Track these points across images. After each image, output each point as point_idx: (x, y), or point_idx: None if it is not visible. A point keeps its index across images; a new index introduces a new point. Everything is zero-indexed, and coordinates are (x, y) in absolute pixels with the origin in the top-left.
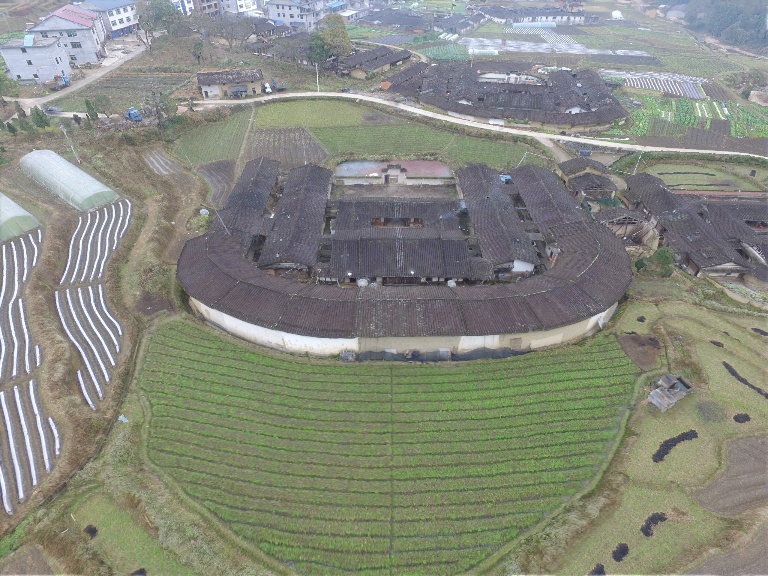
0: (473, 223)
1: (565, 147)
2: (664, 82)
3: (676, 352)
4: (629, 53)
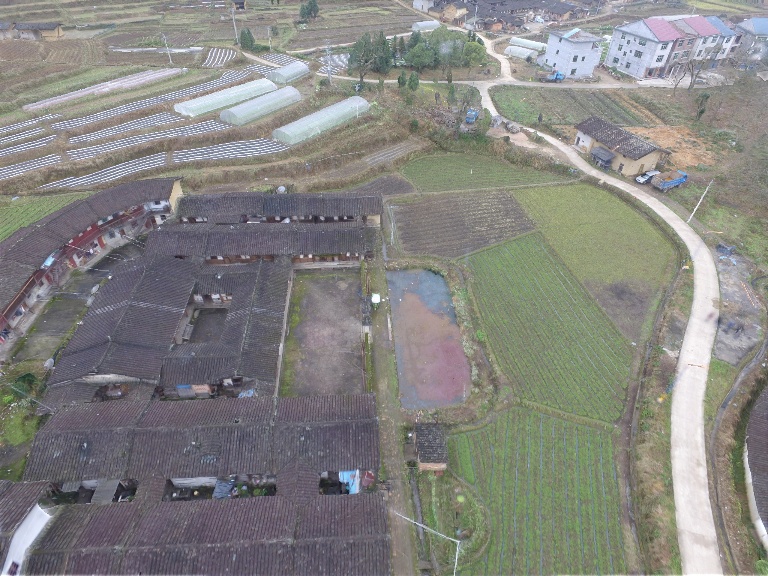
0: None
1: None
2: None
3: None
4: None
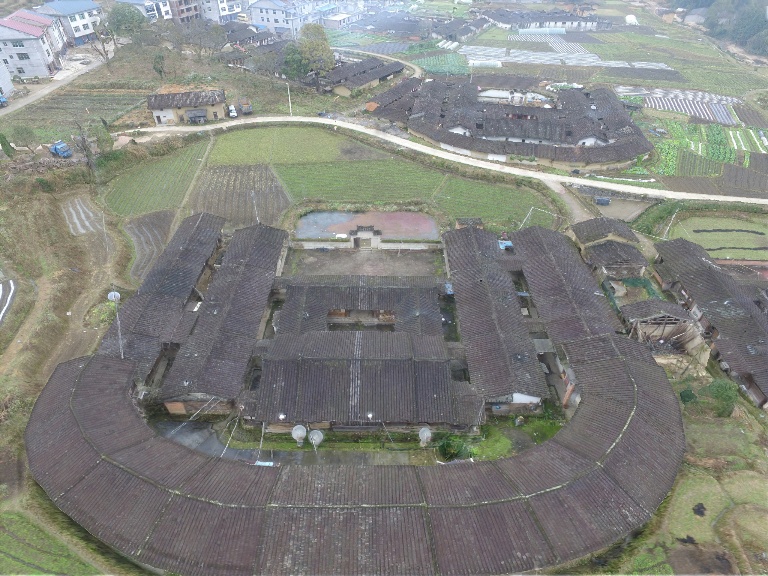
0: (460, 321)
1: (579, 194)
2: (690, 103)
3: None
4: (647, 65)
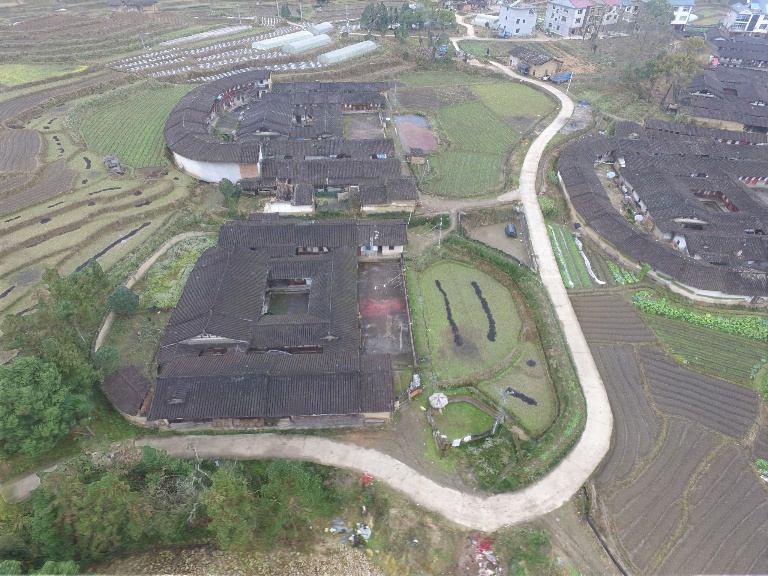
0: None
1: (501, 208)
2: None
3: (141, 179)
4: None
